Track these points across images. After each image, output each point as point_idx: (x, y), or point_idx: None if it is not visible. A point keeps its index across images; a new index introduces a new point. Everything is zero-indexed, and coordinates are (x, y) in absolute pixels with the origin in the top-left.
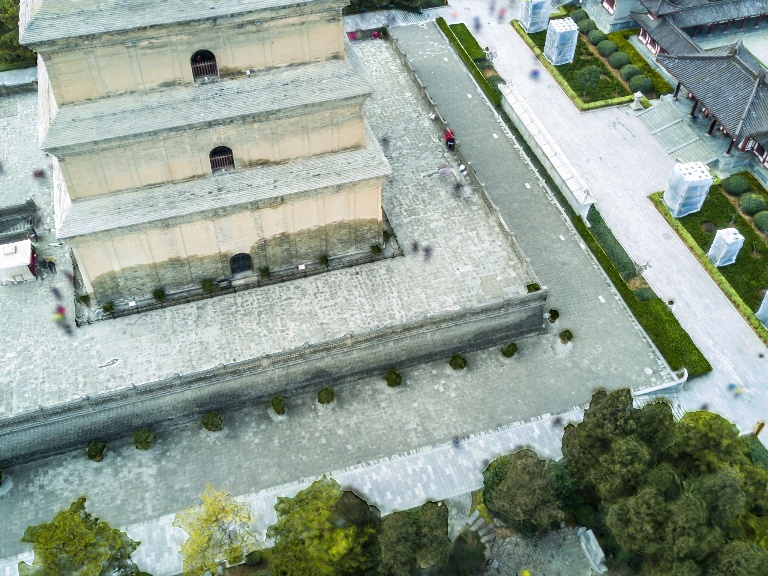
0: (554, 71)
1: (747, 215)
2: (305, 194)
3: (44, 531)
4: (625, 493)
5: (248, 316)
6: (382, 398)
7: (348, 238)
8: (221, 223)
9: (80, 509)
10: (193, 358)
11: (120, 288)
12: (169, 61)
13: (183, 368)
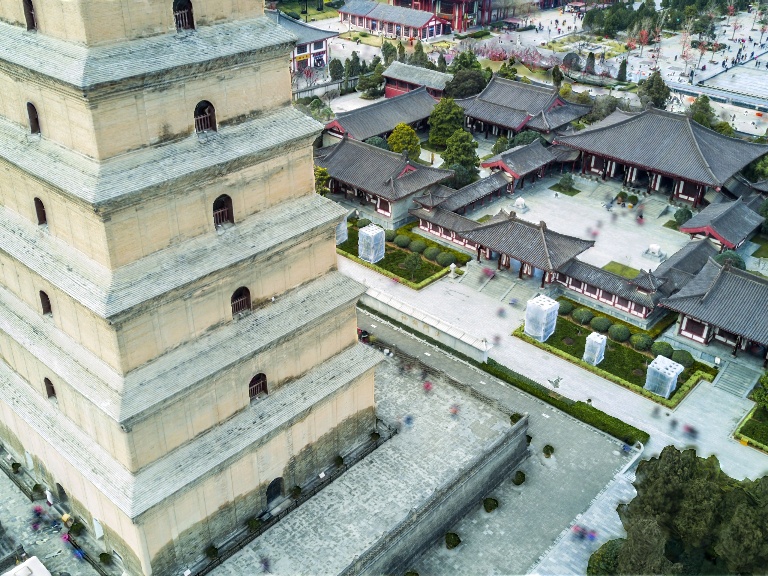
0: (377, 267)
1: (584, 325)
2: (326, 399)
3: None
4: (717, 522)
5: (307, 536)
6: (451, 562)
7: (353, 433)
8: (262, 452)
9: None
10: None
11: (175, 559)
12: (216, 304)
13: None
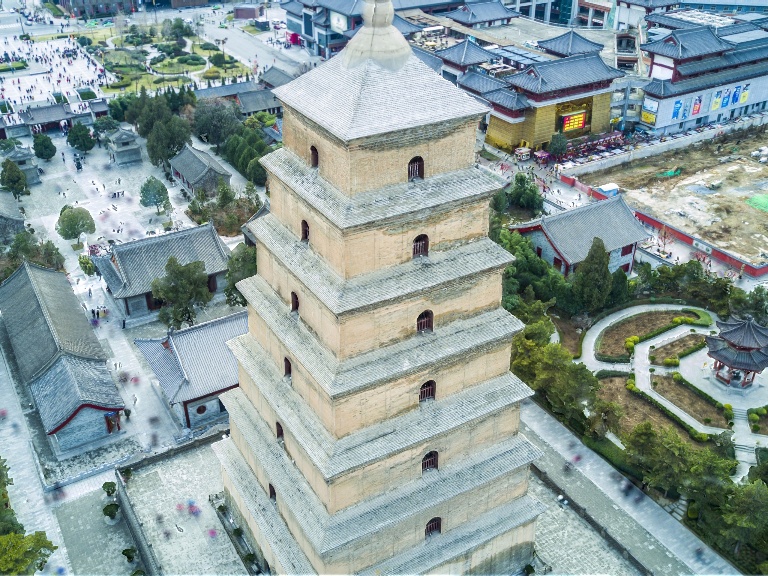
0: None
1: None
2: None
3: (34, 537)
4: None
5: None
6: None
7: None
8: None
9: (51, 549)
10: (187, 574)
11: None
12: None
13: (177, 571)
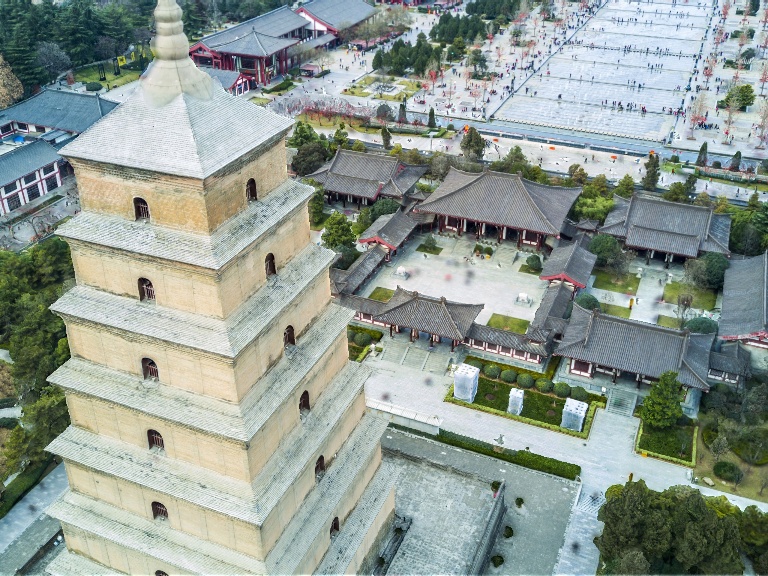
0: None
1: None
2: None
3: None
4: (674, 538)
5: None
6: None
7: (385, 535)
8: None
9: None
10: None
11: None
12: (308, 478)
13: None
